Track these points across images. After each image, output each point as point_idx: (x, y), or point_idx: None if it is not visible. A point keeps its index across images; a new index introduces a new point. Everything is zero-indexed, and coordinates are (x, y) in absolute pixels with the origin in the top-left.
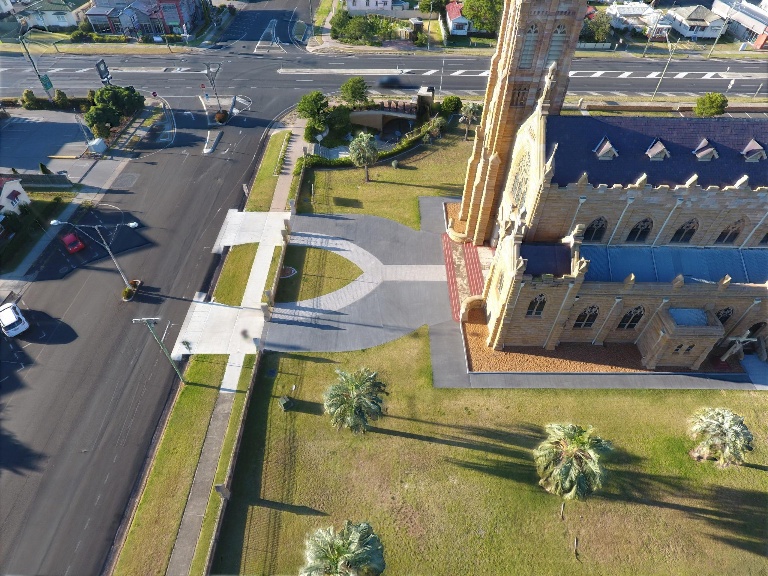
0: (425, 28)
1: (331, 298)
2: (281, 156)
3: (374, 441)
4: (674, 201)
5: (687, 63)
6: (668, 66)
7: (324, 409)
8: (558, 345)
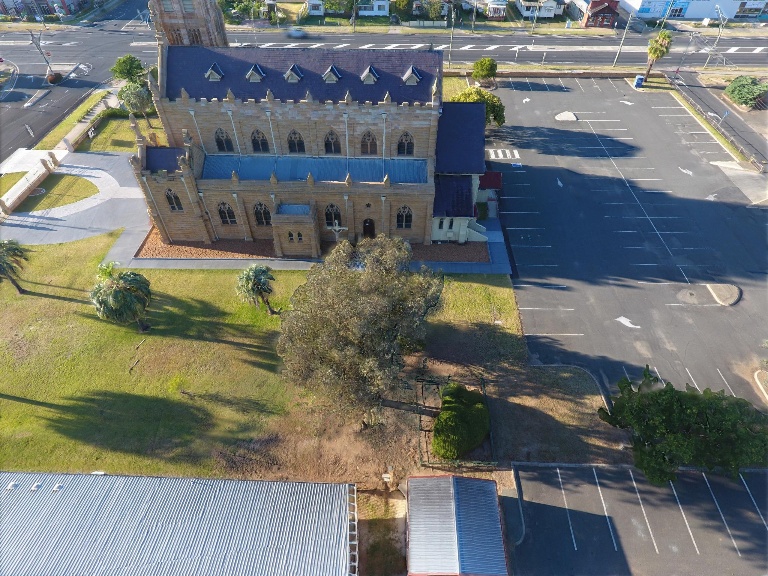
0: (291, 10)
1: (60, 209)
2: (89, 109)
3: (26, 301)
4: (265, 113)
5: (507, 38)
6: (487, 40)
7: (1, 280)
8: (216, 240)
